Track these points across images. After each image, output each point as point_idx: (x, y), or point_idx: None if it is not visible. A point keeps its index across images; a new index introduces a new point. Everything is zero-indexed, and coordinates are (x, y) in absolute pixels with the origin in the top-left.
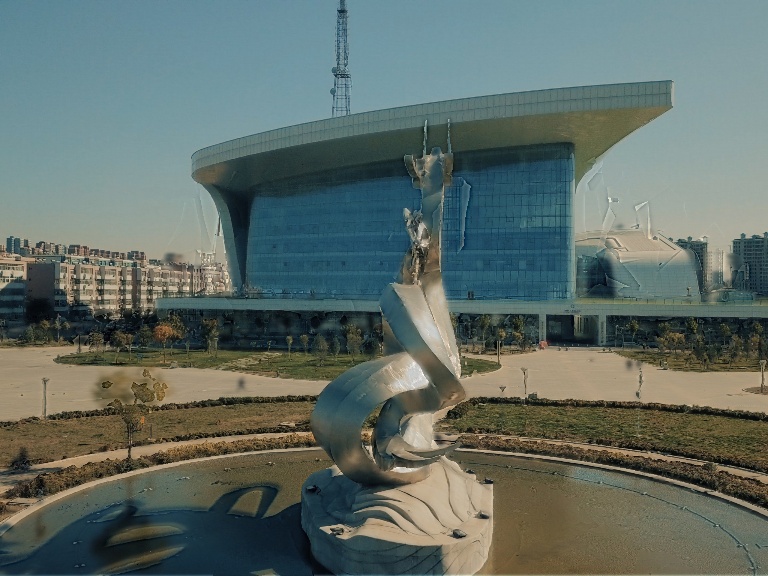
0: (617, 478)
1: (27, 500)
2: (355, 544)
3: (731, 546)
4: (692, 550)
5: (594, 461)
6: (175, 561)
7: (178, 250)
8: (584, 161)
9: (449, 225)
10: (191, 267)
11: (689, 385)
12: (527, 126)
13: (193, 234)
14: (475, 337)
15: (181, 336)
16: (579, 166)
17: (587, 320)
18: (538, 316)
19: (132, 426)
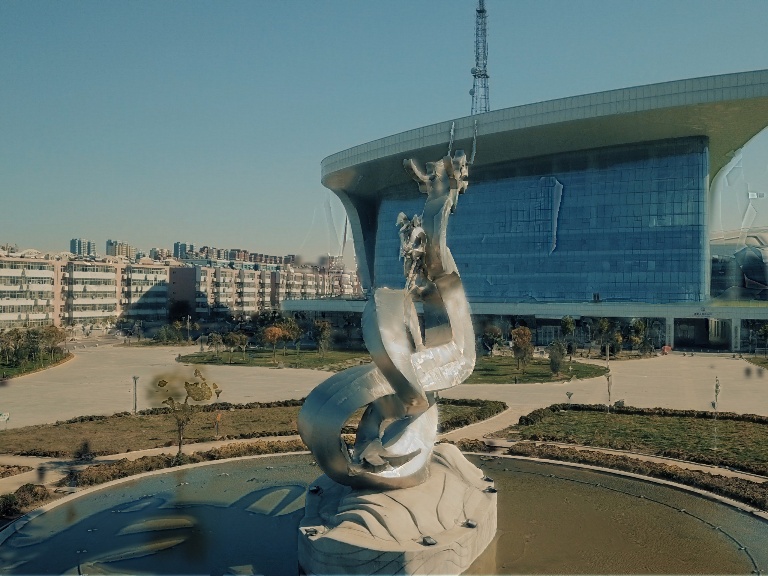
0: (663, 493)
1: (73, 489)
2: (321, 546)
3: (744, 571)
4: (698, 573)
5: (647, 474)
6: (170, 552)
7: (310, 254)
8: (721, 155)
9: (541, 226)
10: (323, 270)
11: None
12: (654, 120)
13: (324, 238)
14: (593, 341)
15: (293, 337)
16: (714, 160)
17: (724, 324)
18: (665, 319)
19: (182, 423)
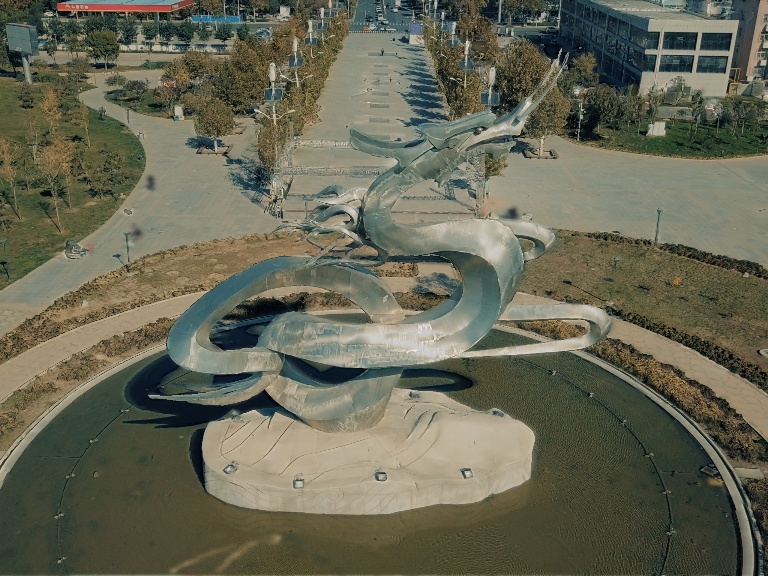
0: None
1: None
2: None
3: None
4: None
5: None
6: None
7: None
8: None
9: None
10: None
11: None
12: None
13: None
14: None
15: None
16: None
17: None
18: None
19: None
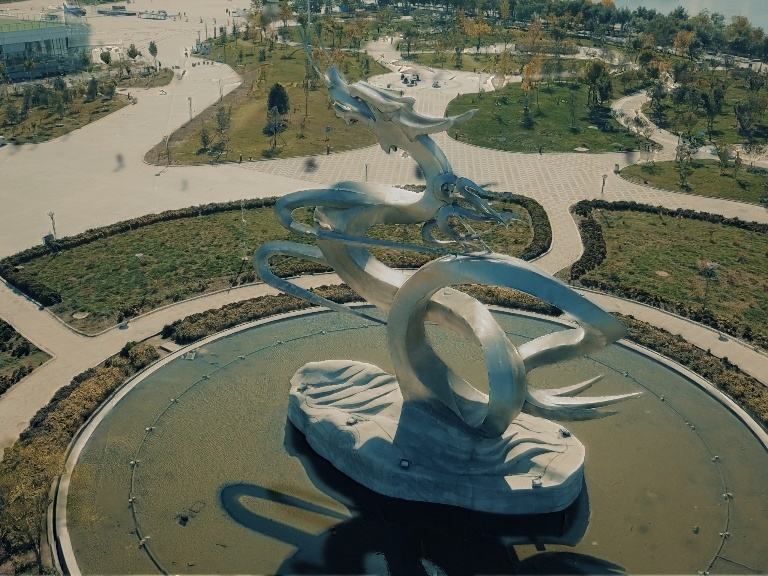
0: None
1: None
2: (567, 483)
3: None
4: None
5: (310, 306)
6: None
7: None
8: None
9: None
10: None
11: (95, 168)
12: None
13: None
14: None
15: None
16: None
17: None
18: None
19: (40, 530)
